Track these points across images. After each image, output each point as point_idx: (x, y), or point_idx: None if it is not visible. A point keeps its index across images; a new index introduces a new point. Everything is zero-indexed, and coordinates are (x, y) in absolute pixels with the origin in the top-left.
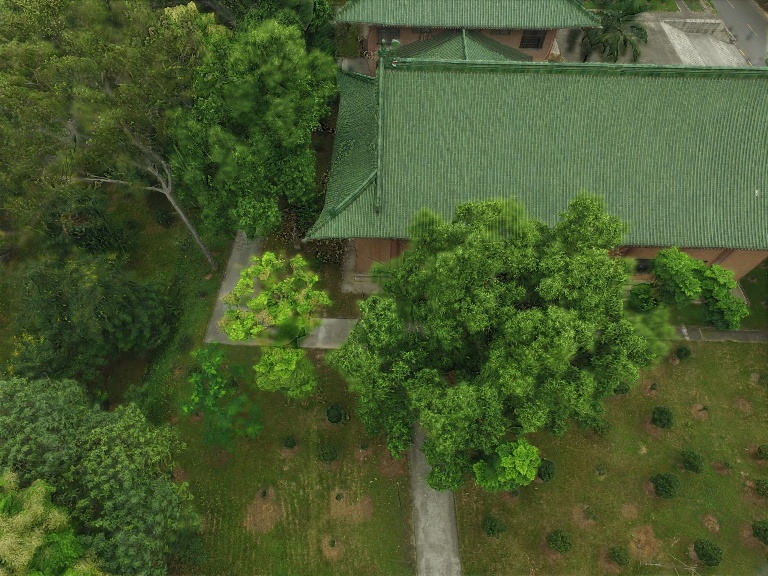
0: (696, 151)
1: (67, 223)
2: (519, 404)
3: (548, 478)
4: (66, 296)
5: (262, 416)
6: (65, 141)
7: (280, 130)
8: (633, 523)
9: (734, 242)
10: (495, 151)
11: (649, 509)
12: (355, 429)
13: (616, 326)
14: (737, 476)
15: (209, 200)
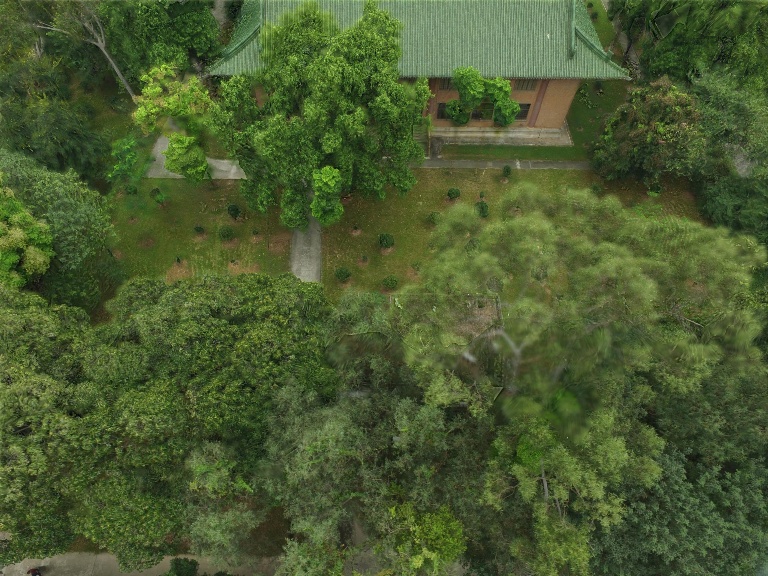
0: (501, 5)
1: (30, 86)
2: (322, 135)
3: (386, 243)
4: (28, 128)
5: (182, 219)
6: (29, 35)
7: None
8: (450, 277)
9: (530, 73)
10: (350, 8)
11: (464, 269)
12: (251, 225)
13: (379, 75)
14: (534, 249)
15: (133, 48)
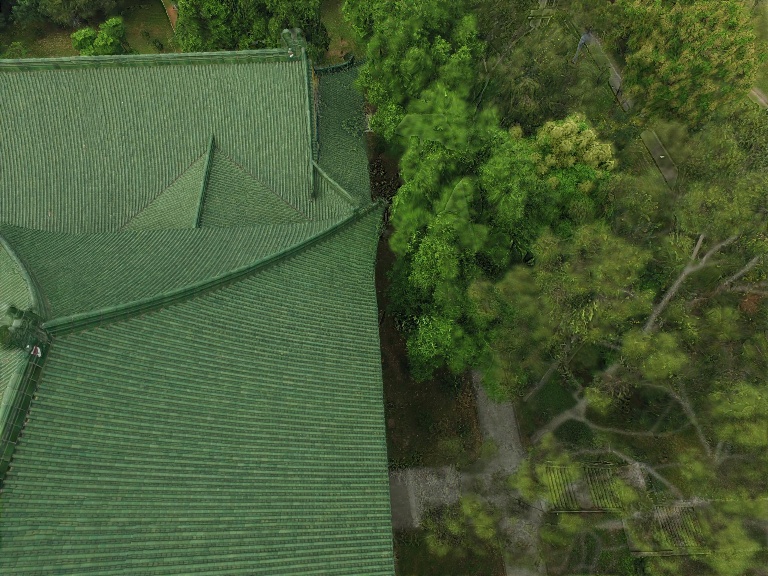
0: None
1: None
2: None
3: None
4: None
5: None
6: None
7: (472, 319)
8: None
9: None
10: None
11: None
12: None
13: None
14: None
15: None
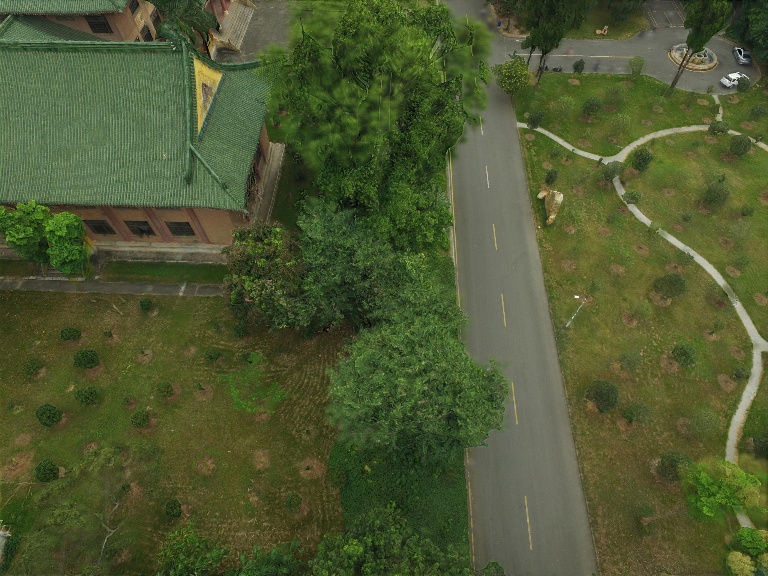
0: (109, 119)
1: None
2: None
3: None
4: None
5: None
6: None
7: None
8: (20, 449)
9: (139, 200)
10: None
11: (42, 438)
12: None
13: None
14: None
15: None
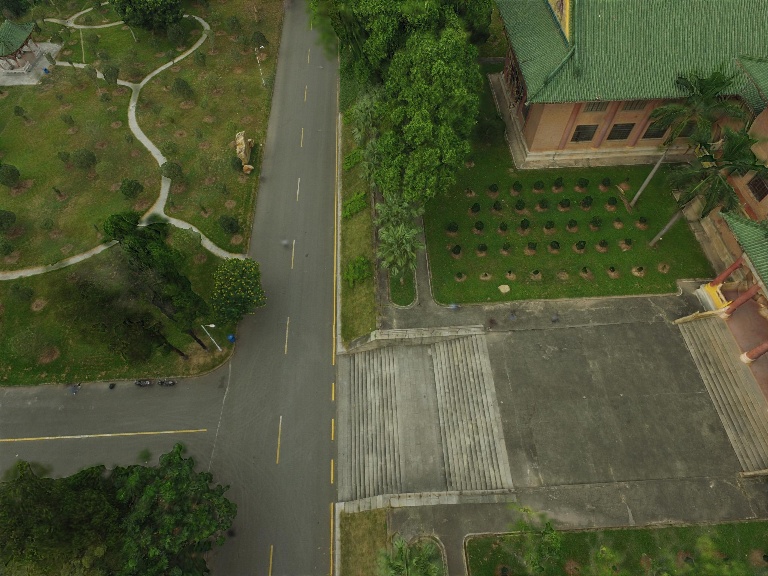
0: None
1: None
2: None
3: None
4: None
5: None
6: None
7: None
8: None
9: None
10: None
11: None
12: None
13: None
14: None
15: None
